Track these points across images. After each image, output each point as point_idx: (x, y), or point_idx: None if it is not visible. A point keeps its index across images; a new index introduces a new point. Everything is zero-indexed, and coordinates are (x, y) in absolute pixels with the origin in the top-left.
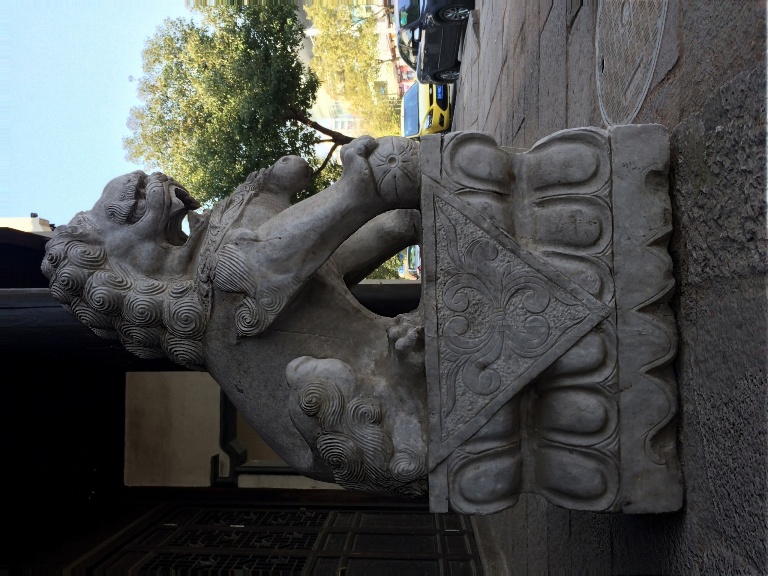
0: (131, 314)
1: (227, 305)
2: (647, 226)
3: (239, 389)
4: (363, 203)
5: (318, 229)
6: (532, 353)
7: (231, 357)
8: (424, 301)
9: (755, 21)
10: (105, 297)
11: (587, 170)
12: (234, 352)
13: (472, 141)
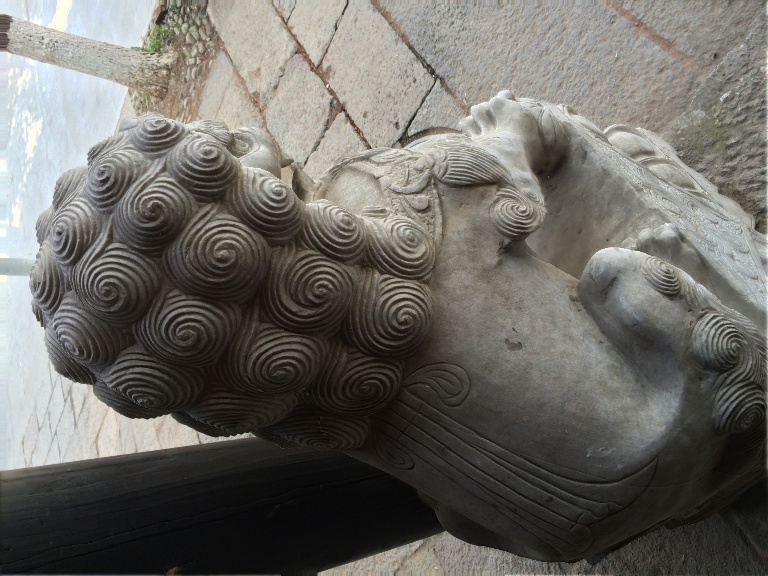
0: (328, 226)
1: (469, 210)
2: (707, 182)
3: (514, 344)
4: (529, 141)
5: (520, 142)
6: (744, 249)
7: (491, 290)
8: (648, 207)
9: (639, 107)
10: (288, 188)
11: (649, 145)
12: (494, 280)
13: (573, 114)
